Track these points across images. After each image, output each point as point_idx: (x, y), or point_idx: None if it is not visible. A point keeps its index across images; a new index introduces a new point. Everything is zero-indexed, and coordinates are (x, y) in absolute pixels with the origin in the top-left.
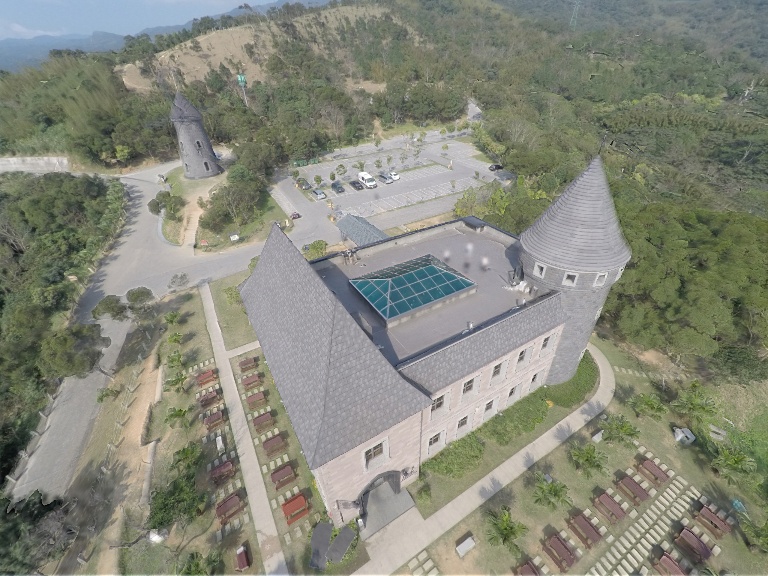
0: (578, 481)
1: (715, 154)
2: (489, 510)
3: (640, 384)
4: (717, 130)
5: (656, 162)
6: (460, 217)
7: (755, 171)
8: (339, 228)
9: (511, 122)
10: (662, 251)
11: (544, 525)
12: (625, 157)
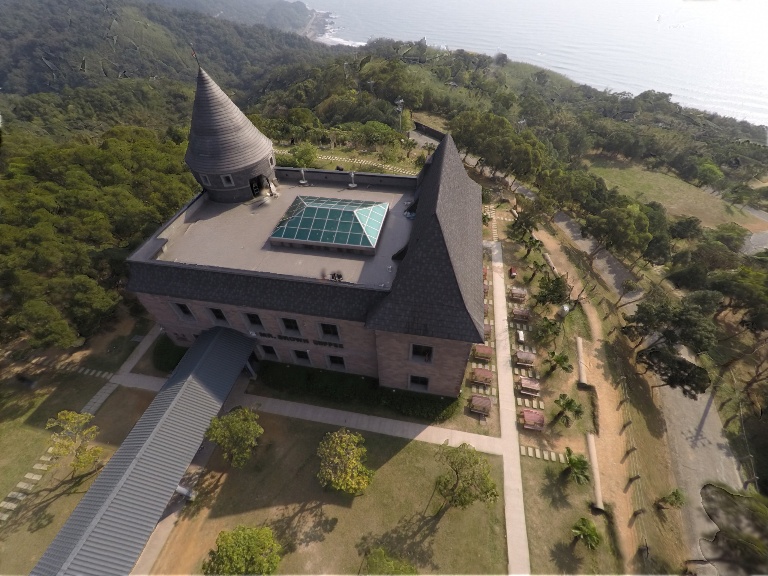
0: None
1: None
2: None
3: None
4: None
5: None
6: None
7: None
8: None
9: None
10: (119, 183)
11: None
12: None
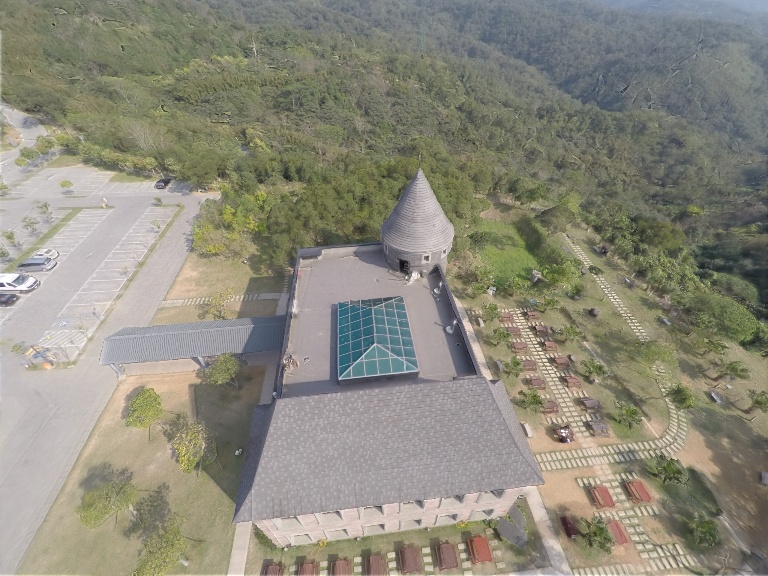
0: (502, 350)
1: (276, 105)
2: (519, 402)
3: (454, 282)
4: (264, 86)
5: (254, 124)
6: (209, 254)
7: (306, 112)
8: (117, 363)
9: (125, 127)
10: None
11: (521, 382)
12: (229, 127)
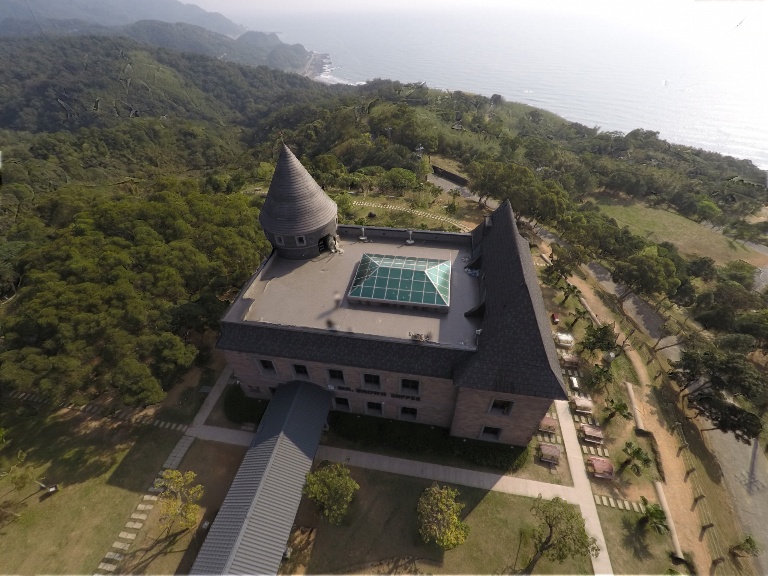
0: None
1: None
2: None
3: None
4: None
5: None
6: None
7: None
8: None
9: None
10: (182, 237)
11: None
12: None
